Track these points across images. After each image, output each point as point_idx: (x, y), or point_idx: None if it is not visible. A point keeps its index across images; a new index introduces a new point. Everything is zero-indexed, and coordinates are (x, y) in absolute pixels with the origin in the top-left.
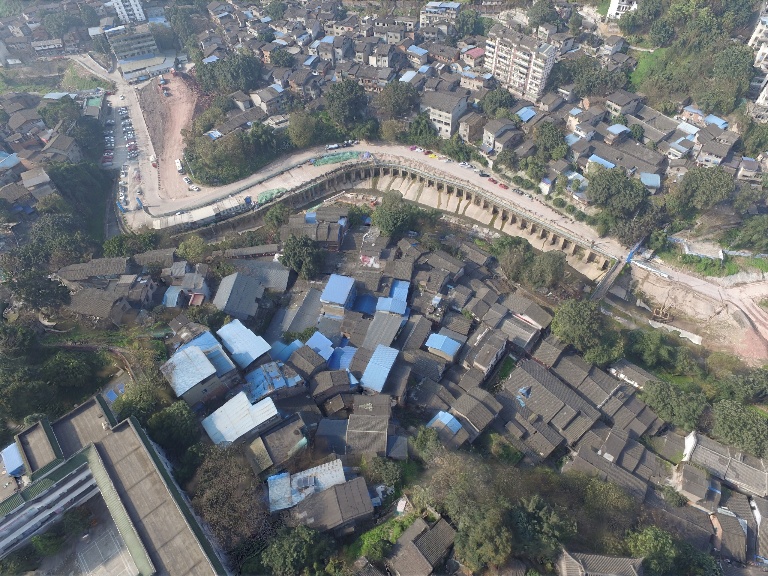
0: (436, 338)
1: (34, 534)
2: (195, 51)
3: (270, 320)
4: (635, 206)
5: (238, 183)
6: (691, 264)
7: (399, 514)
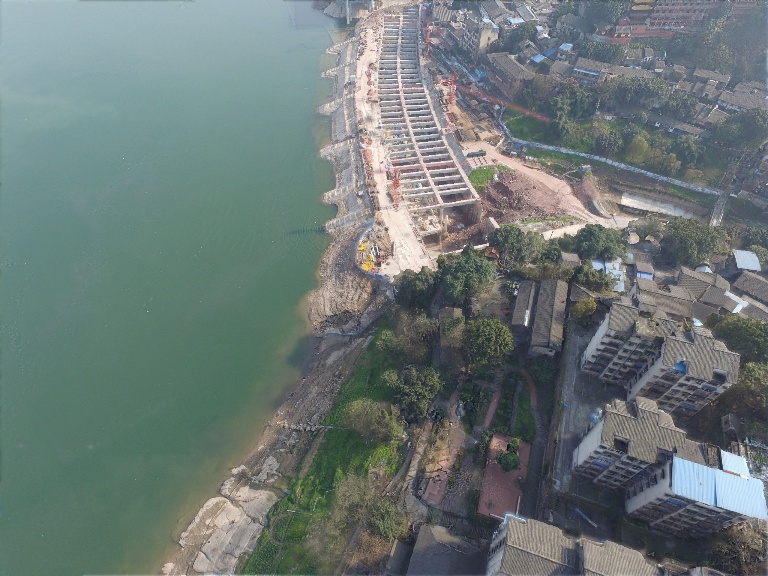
0: None
1: None
2: None
3: None
4: None
5: None
6: None
7: None
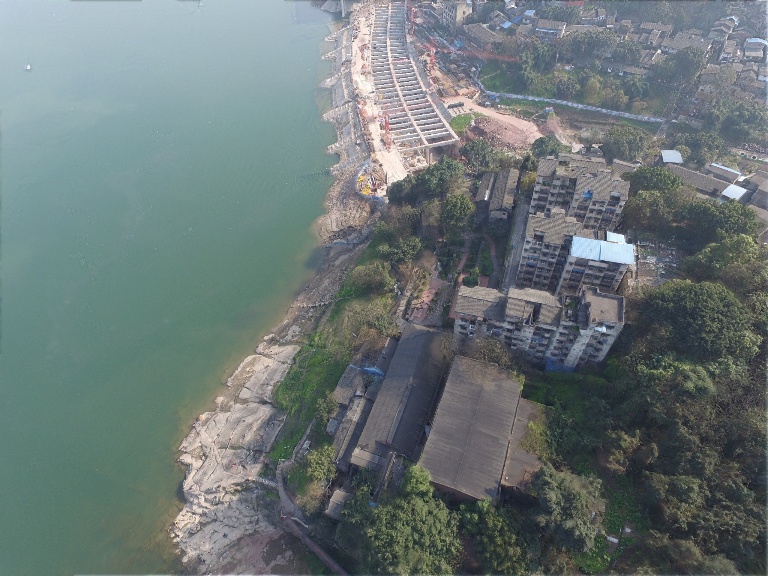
0: (764, 42)
1: None
2: None
3: None
4: None
5: None
6: None
7: None
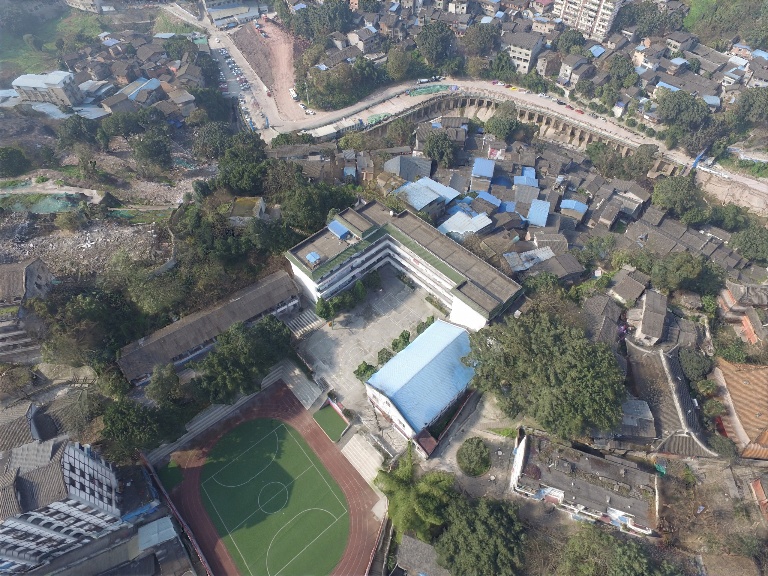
0: (568, 202)
1: (347, 287)
2: (279, 1)
3: None
4: (701, 119)
5: (347, 109)
6: (746, 168)
7: (598, 278)
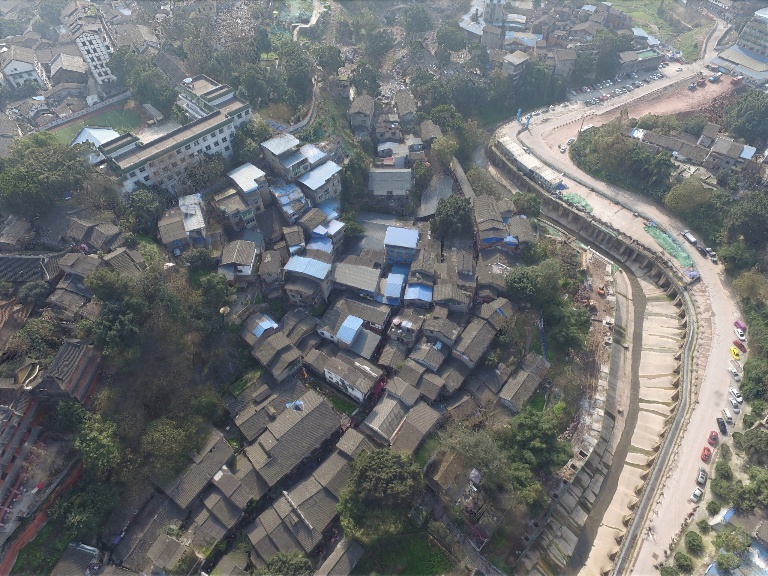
0: (356, 322)
1: None
2: None
3: (383, 212)
4: None
5: (585, 175)
6: None
7: None
